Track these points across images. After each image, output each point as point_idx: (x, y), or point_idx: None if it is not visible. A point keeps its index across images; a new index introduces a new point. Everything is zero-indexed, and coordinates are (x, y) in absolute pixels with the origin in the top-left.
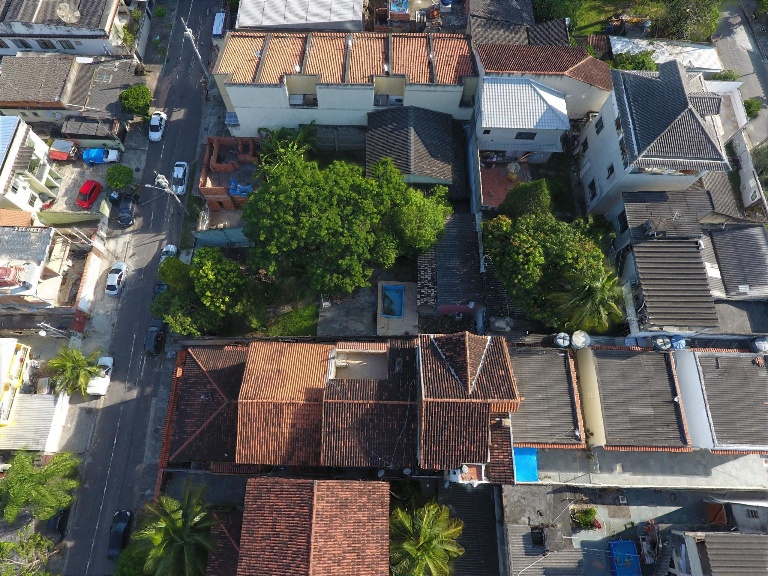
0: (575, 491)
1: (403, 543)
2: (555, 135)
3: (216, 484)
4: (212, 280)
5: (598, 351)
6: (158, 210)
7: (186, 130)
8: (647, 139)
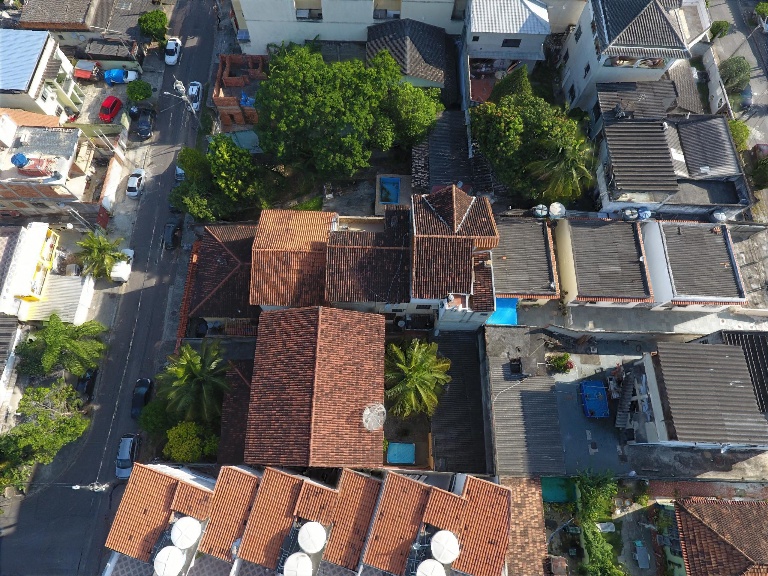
0: (550, 335)
1: (397, 363)
2: (538, 42)
3: (229, 354)
4: (227, 160)
5: (573, 220)
6: (174, 125)
7: (199, 55)
8: (617, 30)
